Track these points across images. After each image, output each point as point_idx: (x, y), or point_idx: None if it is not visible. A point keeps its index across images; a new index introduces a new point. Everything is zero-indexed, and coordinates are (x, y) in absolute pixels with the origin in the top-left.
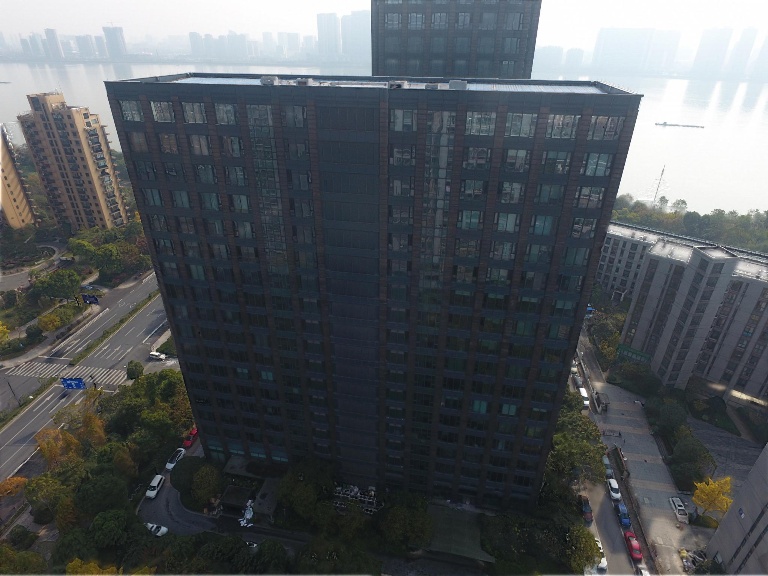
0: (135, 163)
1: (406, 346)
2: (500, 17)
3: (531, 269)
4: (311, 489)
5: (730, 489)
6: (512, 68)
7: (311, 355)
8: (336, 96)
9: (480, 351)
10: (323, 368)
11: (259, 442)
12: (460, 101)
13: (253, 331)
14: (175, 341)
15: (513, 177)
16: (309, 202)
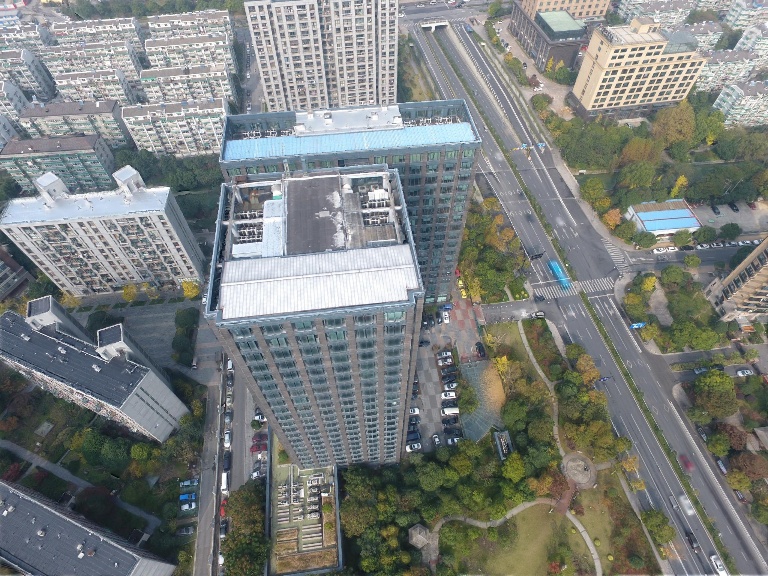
0: None
1: None
2: None
3: None
4: None
5: (171, 319)
6: None
7: None
8: None
9: None
10: None
11: None
12: None
13: None
14: None
15: None
16: None
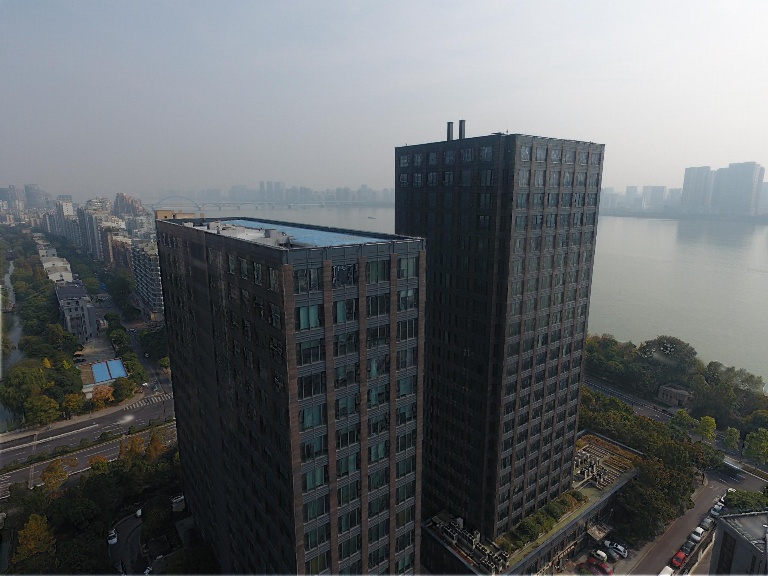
0: None
1: None
2: (474, 174)
3: None
4: (179, 571)
5: None
6: (488, 223)
7: None
8: (194, 235)
9: (256, 495)
10: None
11: None
12: (223, 244)
13: (189, 406)
14: None
15: None
16: None
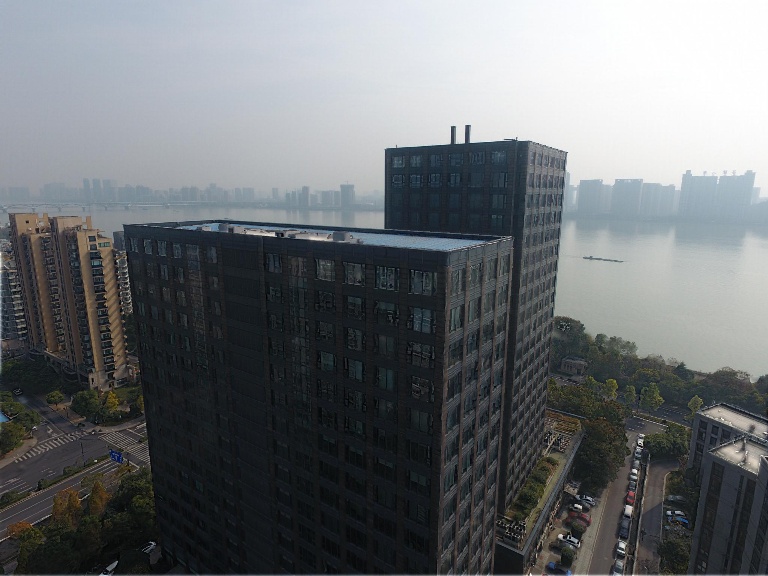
0: (134, 282)
1: (290, 487)
2: (486, 176)
3: (382, 426)
4: None
5: None
6: (501, 222)
7: (225, 474)
8: (233, 240)
9: (350, 513)
10: (234, 491)
11: (195, 557)
12: (308, 249)
13: (190, 437)
14: (148, 433)
15: (354, 324)
16: (221, 326)
